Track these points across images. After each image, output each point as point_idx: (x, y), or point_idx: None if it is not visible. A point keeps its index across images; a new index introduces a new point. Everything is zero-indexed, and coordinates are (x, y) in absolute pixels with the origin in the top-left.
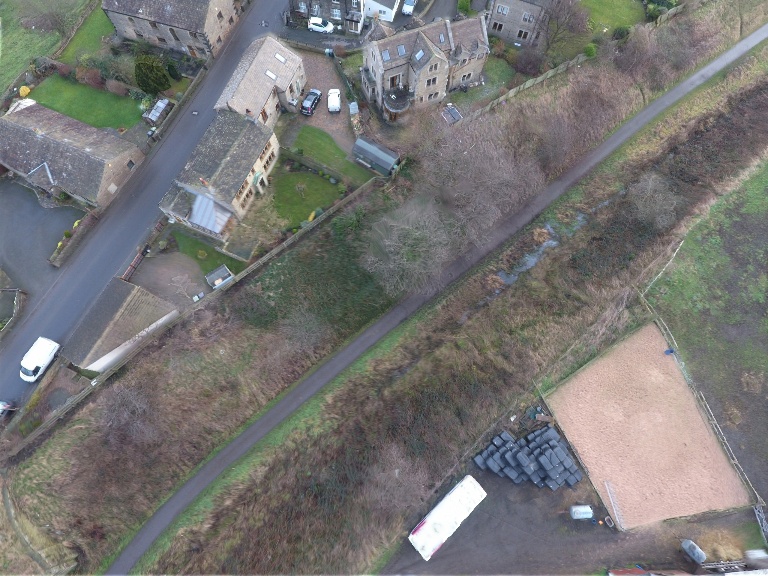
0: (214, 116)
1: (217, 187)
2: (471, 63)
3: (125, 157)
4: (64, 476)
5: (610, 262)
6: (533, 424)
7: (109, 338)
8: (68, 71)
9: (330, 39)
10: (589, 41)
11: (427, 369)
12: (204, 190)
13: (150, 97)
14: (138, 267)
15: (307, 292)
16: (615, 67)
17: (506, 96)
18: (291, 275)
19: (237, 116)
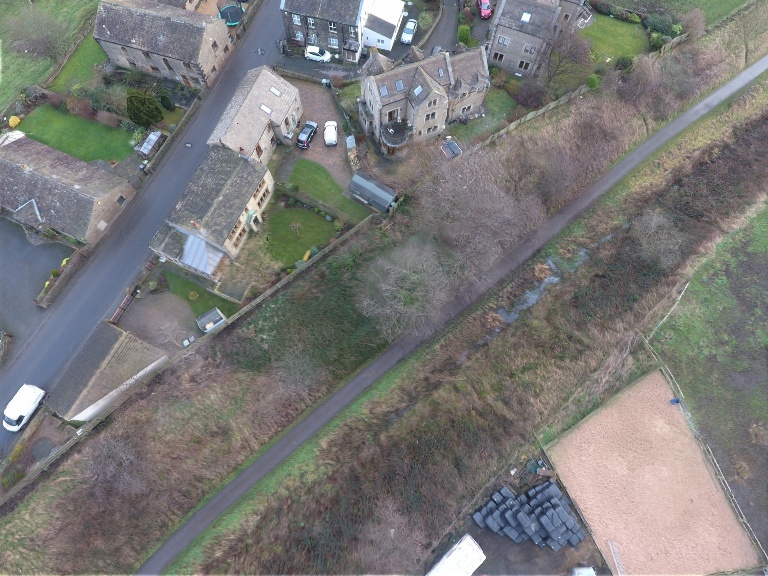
0: (208, 149)
1: (209, 228)
2: (471, 96)
3: (115, 193)
4: (48, 530)
5: (613, 302)
6: (534, 479)
7: (95, 387)
8: (59, 101)
9: (327, 68)
10: (592, 72)
11: (425, 413)
12: (195, 231)
13: (142, 129)
14: (127, 308)
15: (301, 334)
16: (618, 97)
17: (507, 129)
18: (285, 317)
19: (230, 153)
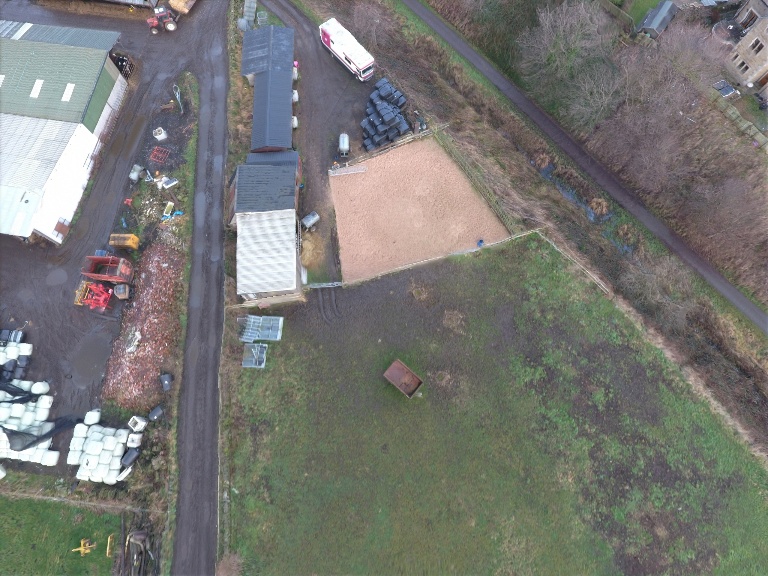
0: None
1: None
2: None
3: None
4: None
5: (574, 237)
6: (412, 120)
7: None
8: None
9: None
10: None
11: (456, 98)
12: None
13: None
14: None
15: None
16: None
17: (765, 142)
18: None
19: None
